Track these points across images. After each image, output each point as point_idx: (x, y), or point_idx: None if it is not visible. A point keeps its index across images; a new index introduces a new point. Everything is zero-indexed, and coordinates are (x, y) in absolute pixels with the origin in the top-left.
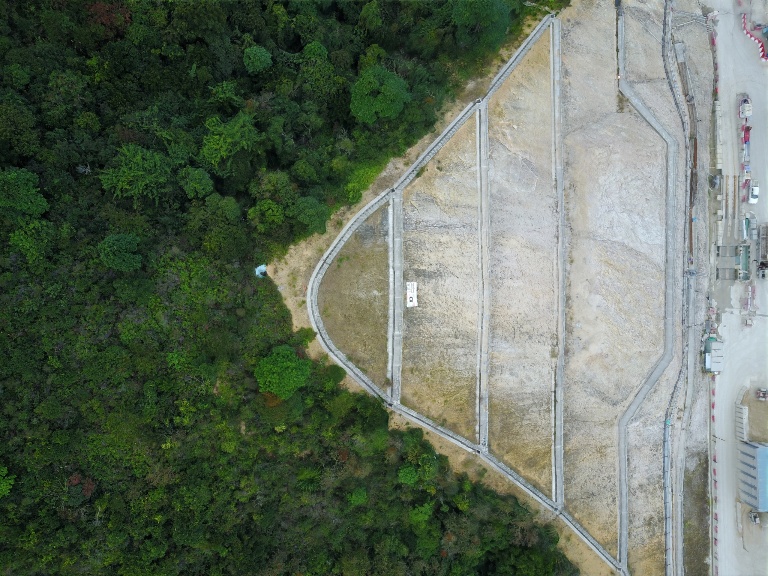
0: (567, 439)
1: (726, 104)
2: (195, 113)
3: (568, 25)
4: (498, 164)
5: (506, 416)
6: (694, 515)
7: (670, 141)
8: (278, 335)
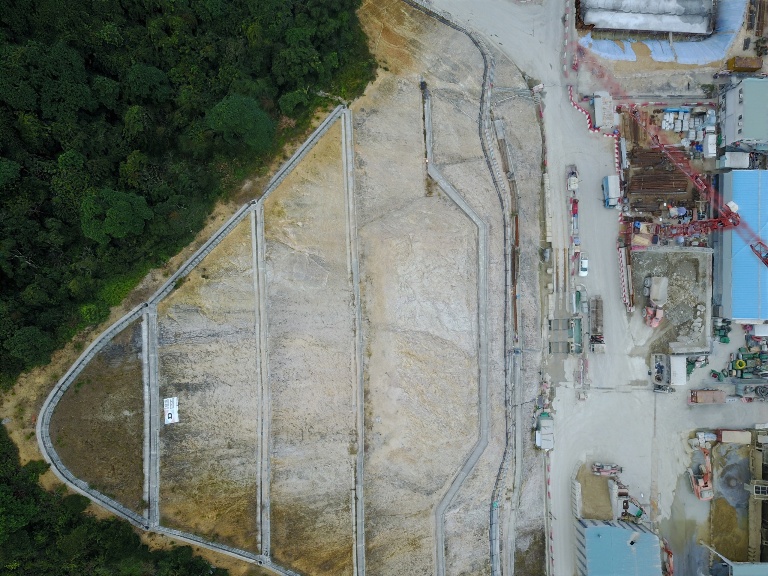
0: (370, 536)
1: (555, 176)
2: None
3: (363, 114)
4: (278, 264)
5: (293, 522)
6: None
7: (480, 224)
8: (0, 472)
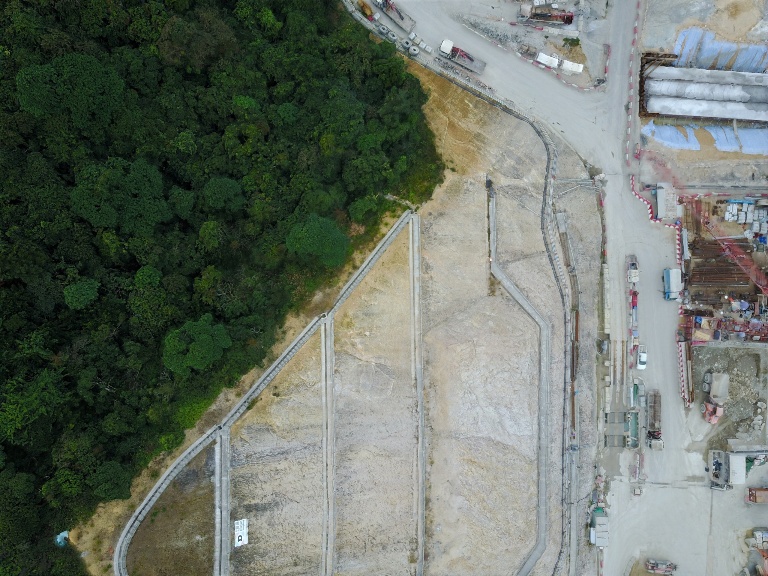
0: None
1: (615, 266)
2: (3, 366)
3: (430, 218)
4: (346, 377)
5: None
6: None
7: (543, 324)
8: None
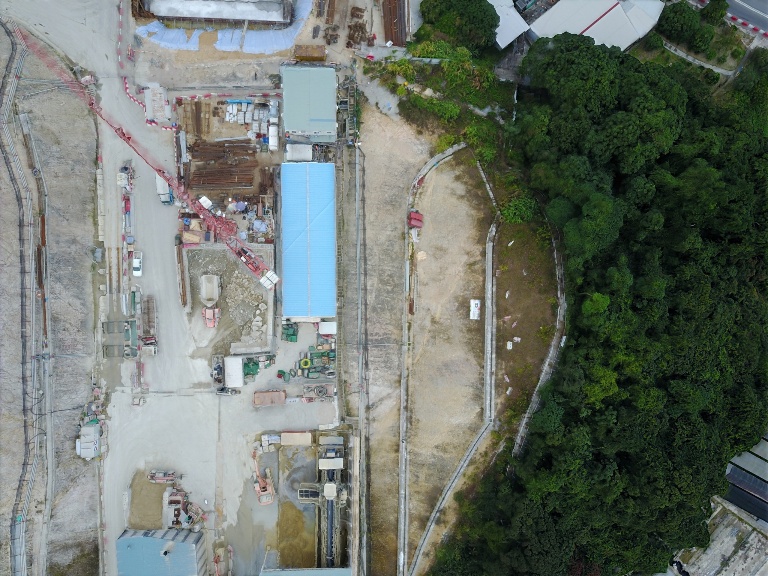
0: None
1: (112, 172)
2: None
3: None
4: None
5: None
6: None
7: None
8: None
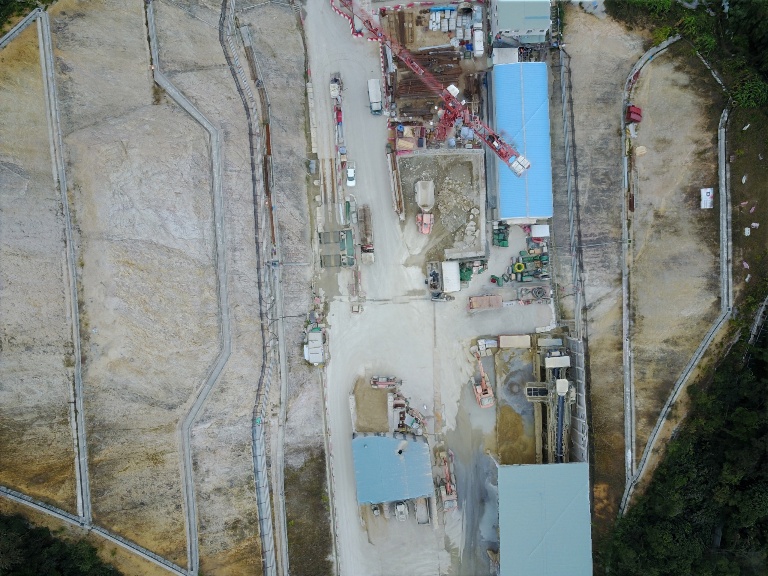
0: (96, 450)
1: (320, 85)
2: None
3: (64, 18)
4: None
5: None
6: (305, 513)
7: (212, 130)
8: None
